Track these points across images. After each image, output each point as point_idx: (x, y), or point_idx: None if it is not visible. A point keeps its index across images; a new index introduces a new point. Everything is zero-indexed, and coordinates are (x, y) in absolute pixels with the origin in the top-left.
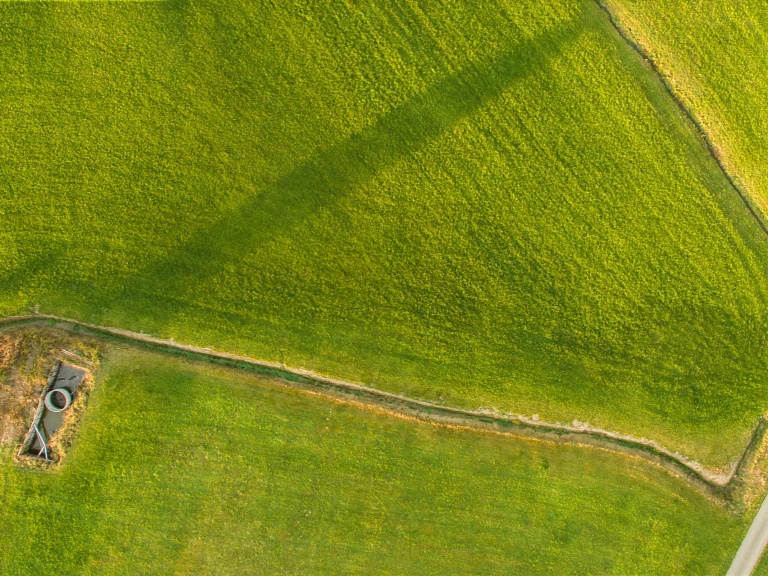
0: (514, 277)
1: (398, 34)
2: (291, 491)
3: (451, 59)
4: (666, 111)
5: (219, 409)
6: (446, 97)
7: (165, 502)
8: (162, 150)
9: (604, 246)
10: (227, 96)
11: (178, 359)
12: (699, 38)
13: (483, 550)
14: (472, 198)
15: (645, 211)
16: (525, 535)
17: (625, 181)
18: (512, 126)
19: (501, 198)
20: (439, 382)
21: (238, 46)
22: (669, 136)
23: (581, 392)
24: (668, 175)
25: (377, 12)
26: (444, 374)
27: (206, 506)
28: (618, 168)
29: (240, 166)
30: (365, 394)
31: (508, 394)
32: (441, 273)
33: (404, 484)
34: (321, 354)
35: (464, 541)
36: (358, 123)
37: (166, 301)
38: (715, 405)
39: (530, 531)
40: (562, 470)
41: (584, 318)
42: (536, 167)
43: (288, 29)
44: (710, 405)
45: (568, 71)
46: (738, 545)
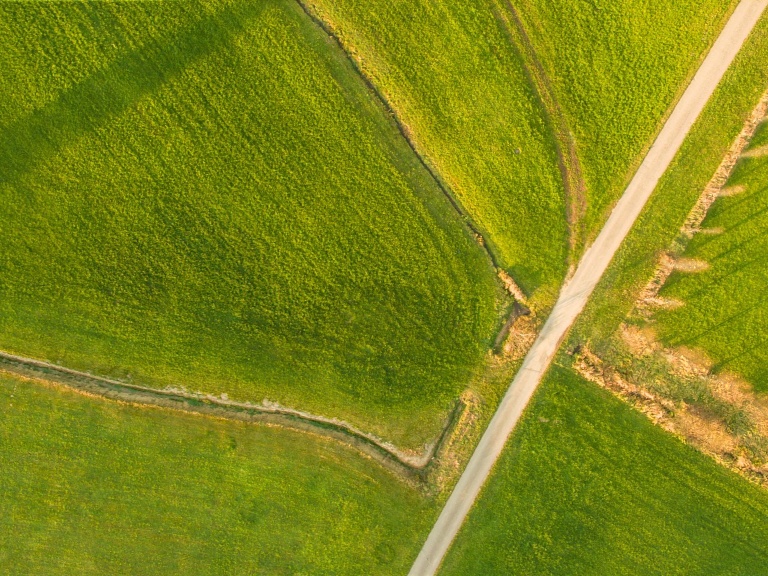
0: (201, 255)
1: (78, 9)
2: None
3: (133, 35)
4: (352, 89)
5: None
6: (128, 73)
7: None
8: None
9: (293, 224)
10: None
11: None
12: (383, 15)
13: (169, 529)
14: (157, 175)
15: (333, 189)
16: (212, 515)
17: (312, 159)
18: (196, 103)
19: (187, 175)
20: (126, 360)
21: None
22: (355, 114)
23: (271, 371)
24: (356, 153)
25: None
26: (131, 352)
27: None
28: (305, 146)
29: None
30: (54, 372)
31: (196, 373)
32: (127, 250)
33: (89, 462)
34: (6, 331)
35: (149, 520)
36: (40, 99)
37: None
38: (409, 386)
39: (217, 511)
40: (250, 450)
41: (274, 297)
42: (221, 144)
43: None
44: (403, 386)
45: (252, 48)
46: (430, 527)
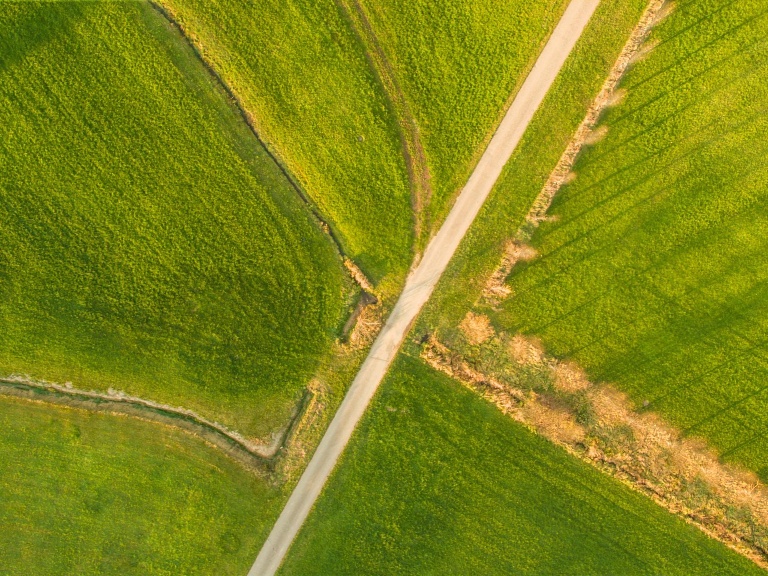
0: (45, 243)
1: None
2: None
3: None
4: (194, 76)
5: None
6: None
7: None
8: None
9: (136, 212)
10: None
11: None
12: (223, 2)
13: (12, 518)
14: None
15: (177, 177)
16: (56, 504)
17: (155, 147)
18: (38, 90)
19: (29, 163)
20: None
21: None
22: (197, 101)
23: (116, 360)
24: (198, 141)
25: None
26: None
27: None
28: (148, 134)
29: None
30: None
31: (40, 361)
32: None
33: None
34: None
35: None
36: None
37: None
38: (255, 375)
39: (61, 500)
40: (95, 438)
41: (119, 285)
42: (64, 132)
43: None
44: (250, 375)
45: (92, 35)
46: (276, 517)
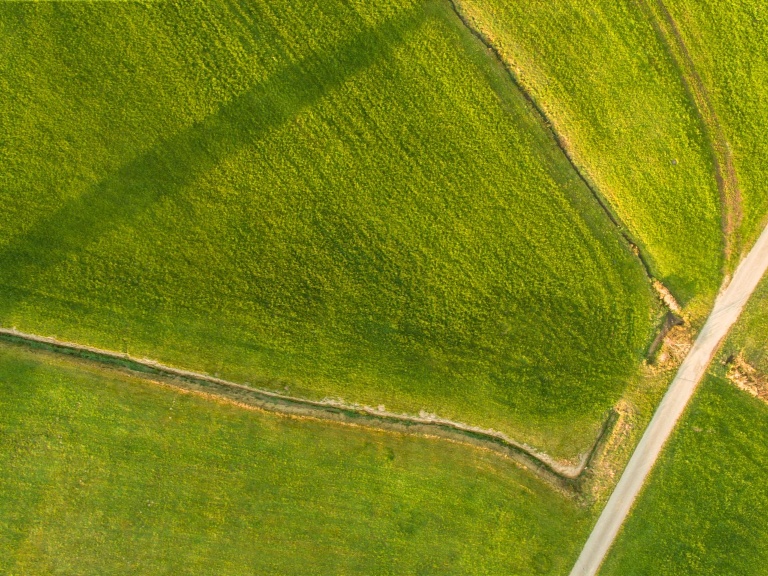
0: (359, 267)
1: (239, 22)
2: (133, 481)
3: (293, 48)
4: (510, 100)
5: (61, 398)
6: (288, 86)
7: (7, 491)
8: (2, 138)
9: (450, 236)
10: (67, 84)
11: (21, 348)
12: (542, 27)
13: (327, 541)
14: (316, 187)
15: (491, 201)
16: (370, 526)
17: (470, 171)
18: (355, 115)
19: (345, 187)
20: (284, 372)
21: (77, 34)
22: (514, 126)
23: (428, 383)
24: (513, 165)
25: (217, 0)
26: (289, 364)
27: (48, 496)
28: (463, 158)
29: (81, 154)
30: (211, 384)
31: (353, 384)
32: (285, 263)
33: (248, 474)
34: (165, 343)
35: (308, 532)
36: (200, 112)
37: (8, 290)
38: (564, 396)
39: (375, 522)
40: (408, 461)
41: (431, 308)
42: (380, 156)
43: (128, 17)
44: (559, 396)
45: (411, 60)
46: (586, 537)
